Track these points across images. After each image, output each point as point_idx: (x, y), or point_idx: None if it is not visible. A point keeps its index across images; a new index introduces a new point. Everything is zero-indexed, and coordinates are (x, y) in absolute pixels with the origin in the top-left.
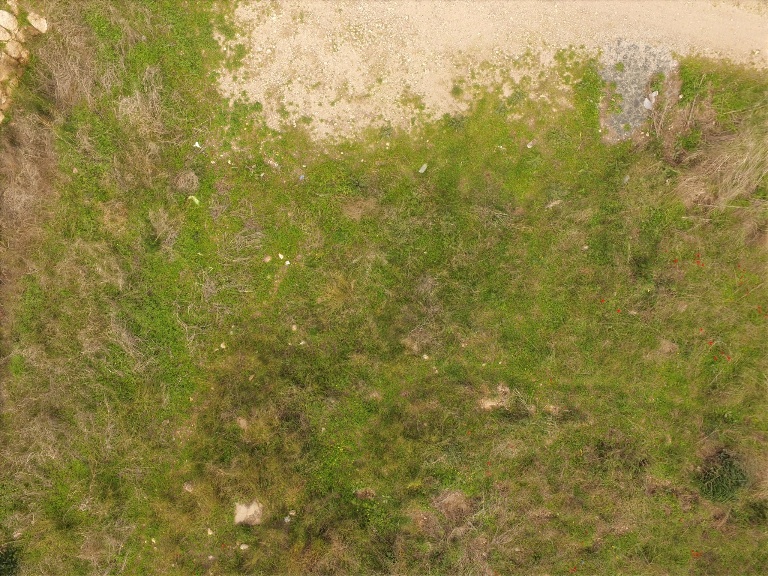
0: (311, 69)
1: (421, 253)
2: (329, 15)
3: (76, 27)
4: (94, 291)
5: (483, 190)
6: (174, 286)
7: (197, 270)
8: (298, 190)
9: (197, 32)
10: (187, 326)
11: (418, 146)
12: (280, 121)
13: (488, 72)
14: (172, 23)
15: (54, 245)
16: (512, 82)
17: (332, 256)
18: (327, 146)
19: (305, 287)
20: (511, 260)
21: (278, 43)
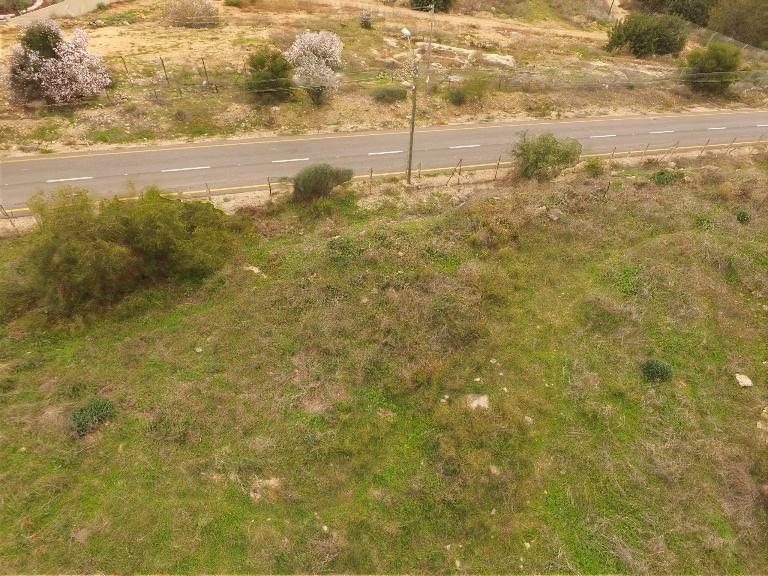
0: None
1: None
2: None
3: None
4: None
5: None
6: None
7: None
8: None
9: None
10: (569, 567)
11: None
12: None
13: None
14: None
15: None
16: None
17: None
18: None
19: None
20: None
21: None
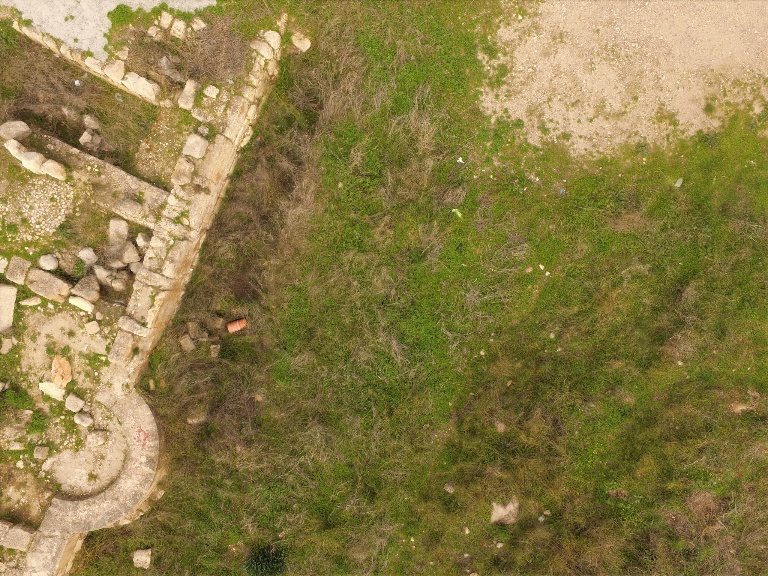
0: (570, 87)
1: (677, 264)
2: (587, 35)
3: (351, 48)
4: (359, 301)
5: (737, 203)
6: (437, 296)
7: (461, 280)
8: (559, 203)
9: (462, 52)
10: (451, 334)
11: (673, 161)
12: (541, 137)
13: (739, 90)
14: (440, 43)
15: (319, 257)
16: (762, 99)
17: (591, 267)
18: (586, 161)
19: (564, 296)
20: (764, 270)
21: (539, 62)
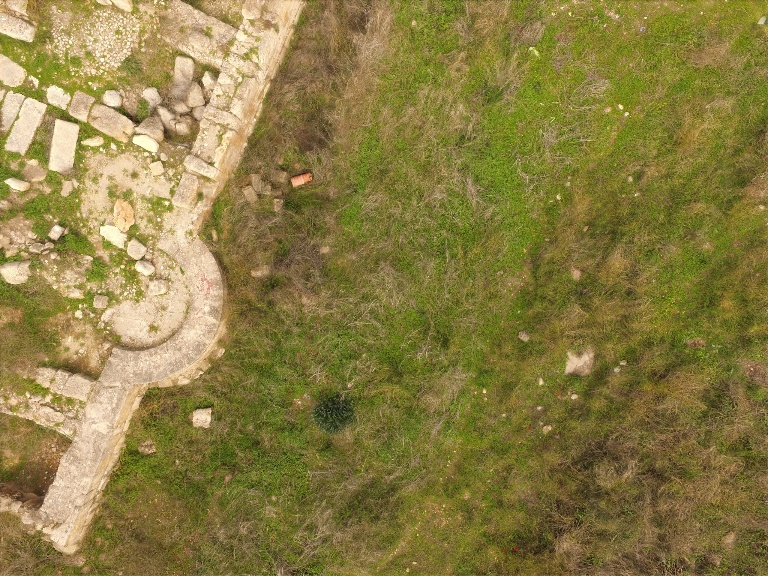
0: None
1: (760, 104)
2: None
3: None
4: (433, 142)
5: None
6: (513, 137)
7: (538, 120)
8: (640, 41)
9: None
10: (527, 176)
11: None
12: None
13: None
14: None
15: (392, 97)
16: None
17: (671, 107)
18: None
19: (643, 138)
20: None
21: None
